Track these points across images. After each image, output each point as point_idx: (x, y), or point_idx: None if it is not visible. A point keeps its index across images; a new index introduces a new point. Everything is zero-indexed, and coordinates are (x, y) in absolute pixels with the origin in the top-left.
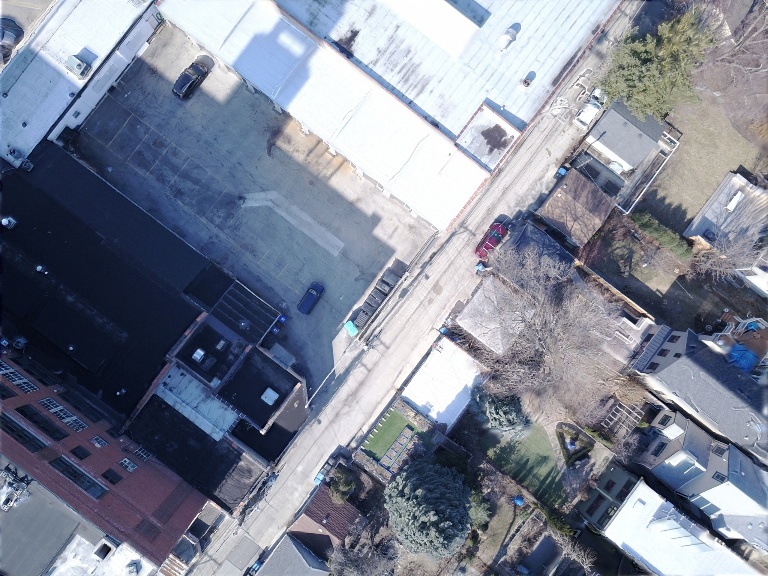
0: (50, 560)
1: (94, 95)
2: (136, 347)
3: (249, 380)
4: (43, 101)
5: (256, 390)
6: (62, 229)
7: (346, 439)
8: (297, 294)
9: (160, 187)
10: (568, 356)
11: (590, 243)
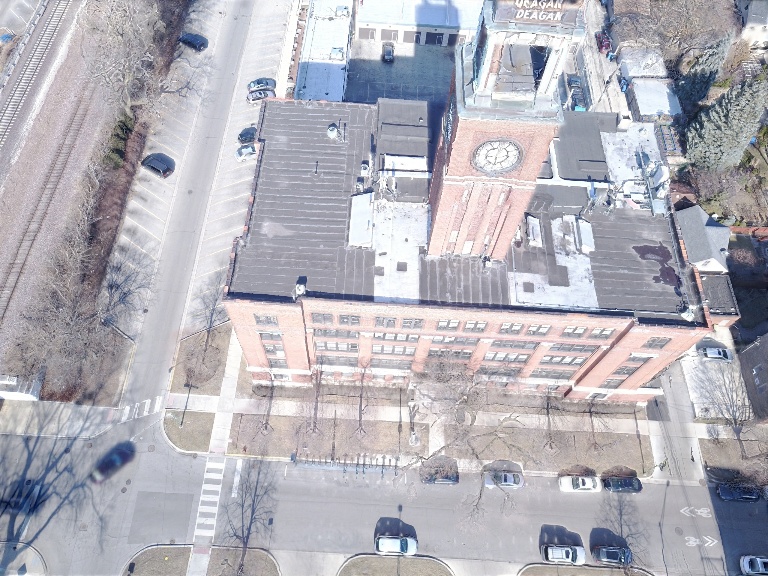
0: None
1: None
2: None
3: None
4: (329, 79)
5: None
6: None
7: None
8: None
9: None
10: (710, 5)
11: (651, 10)
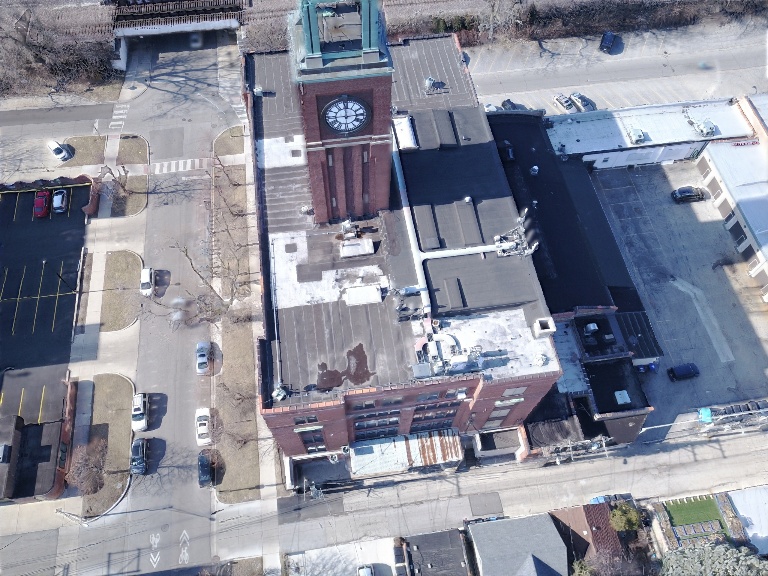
0: (496, 306)
1: (624, 159)
2: (556, 288)
3: (611, 376)
4: (599, 138)
5: (611, 386)
6: (560, 197)
7: (639, 494)
8: (672, 362)
9: (620, 232)
10: None
11: None
